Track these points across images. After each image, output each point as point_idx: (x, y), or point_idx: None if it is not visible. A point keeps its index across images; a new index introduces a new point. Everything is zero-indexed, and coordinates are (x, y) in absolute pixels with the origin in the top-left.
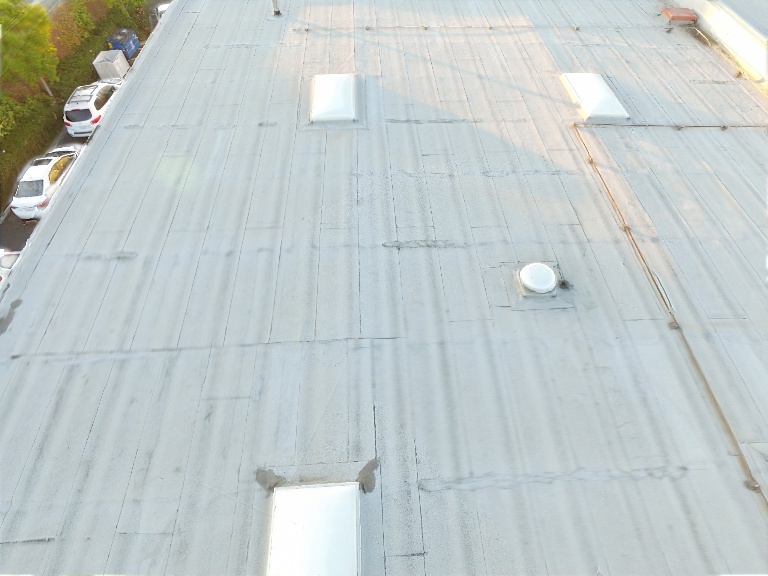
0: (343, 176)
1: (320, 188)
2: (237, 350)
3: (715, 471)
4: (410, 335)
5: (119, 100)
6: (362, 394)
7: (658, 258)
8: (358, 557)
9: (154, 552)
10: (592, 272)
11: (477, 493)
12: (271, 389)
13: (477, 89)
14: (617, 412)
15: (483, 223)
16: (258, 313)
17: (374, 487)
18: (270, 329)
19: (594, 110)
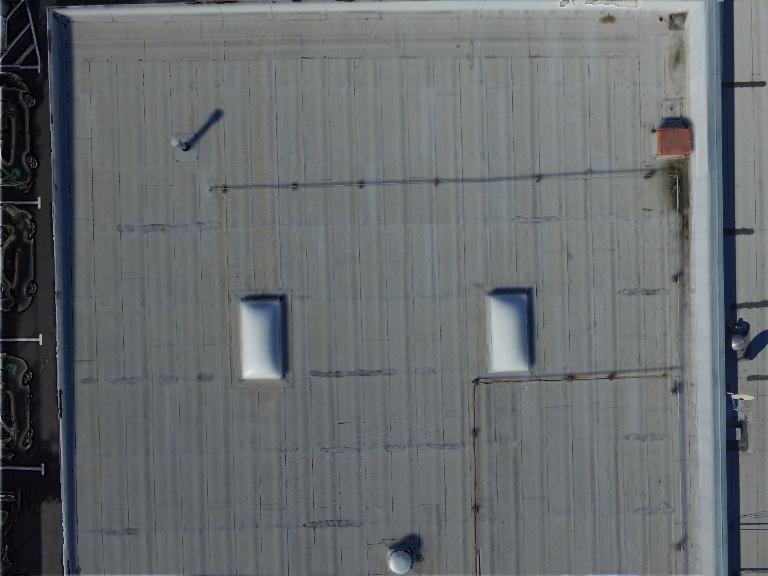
0: (274, 453)
1: (257, 466)
2: None
3: None
4: None
5: (63, 344)
6: None
7: (487, 537)
8: None
9: None
10: (440, 548)
11: None
12: None
13: (400, 320)
14: None
15: (376, 503)
16: None
17: None
18: None
19: (498, 368)
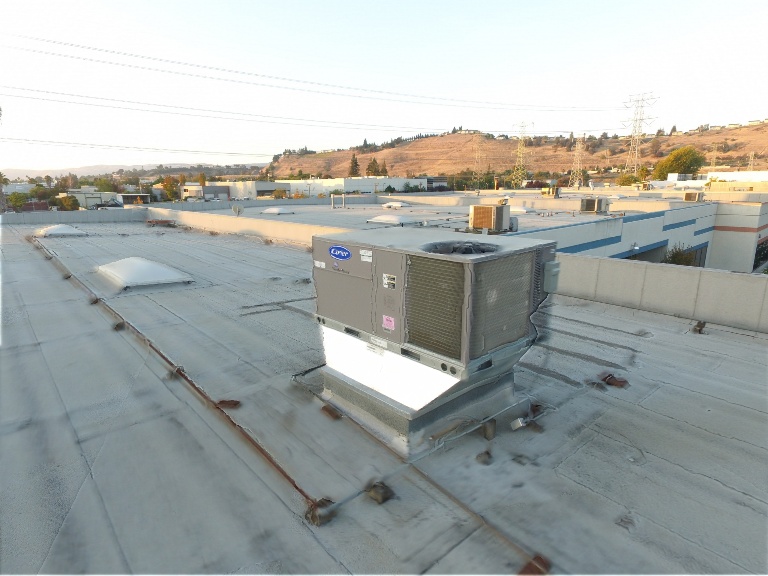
0: None
1: None
2: None
3: None
4: None
5: None
6: None
7: None
8: None
9: None
10: None
11: None
12: None
13: None
14: None
15: None
16: None
17: None
18: None
19: (54, 231)
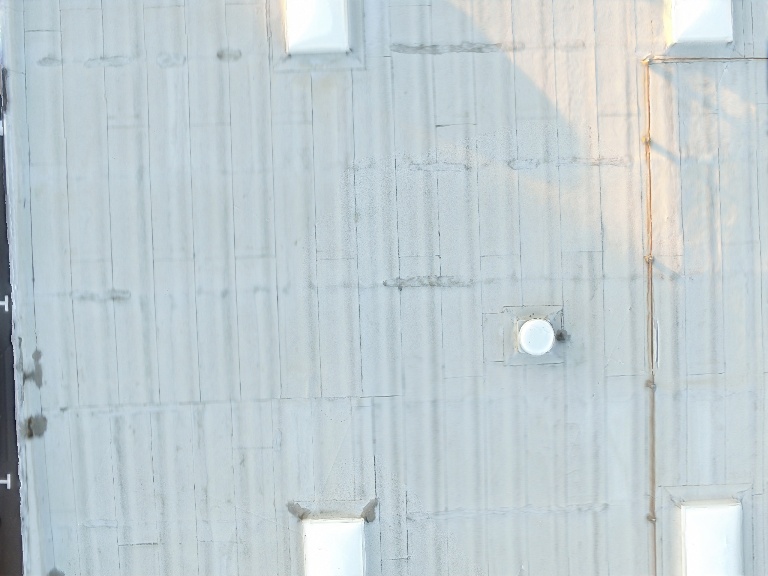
0: (337, 170)
1: (311, 191)
2: (254, 405)
3: (629, 507)
4: (407, 393)
5: (8, 1)
6: (365, 448)
7: (668, 302)
8: (364, 567)
9: (227, 553)
10: (594, 319)
11: (449, 522)
12: (289, 442)
13: None
14: (570, 463)
15: (495, 250)
16: (266, 368)
17: (374, 519)
18: (280, 385)
19: (686, 31)
